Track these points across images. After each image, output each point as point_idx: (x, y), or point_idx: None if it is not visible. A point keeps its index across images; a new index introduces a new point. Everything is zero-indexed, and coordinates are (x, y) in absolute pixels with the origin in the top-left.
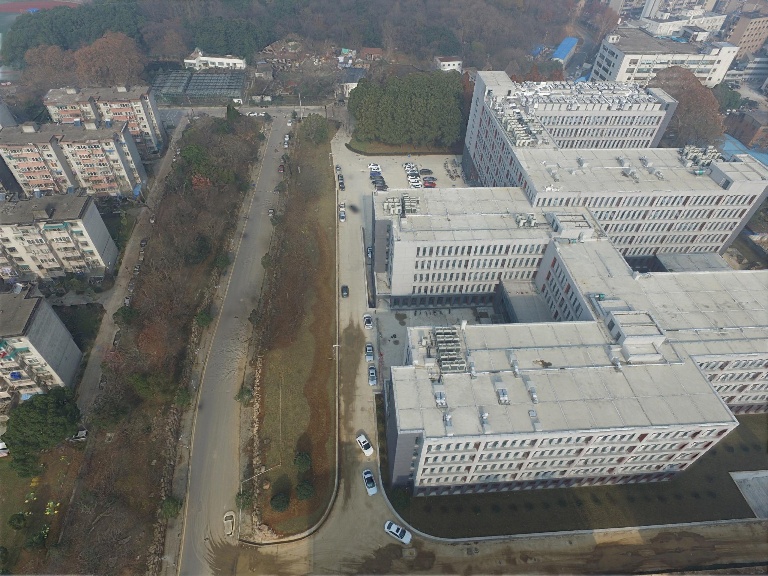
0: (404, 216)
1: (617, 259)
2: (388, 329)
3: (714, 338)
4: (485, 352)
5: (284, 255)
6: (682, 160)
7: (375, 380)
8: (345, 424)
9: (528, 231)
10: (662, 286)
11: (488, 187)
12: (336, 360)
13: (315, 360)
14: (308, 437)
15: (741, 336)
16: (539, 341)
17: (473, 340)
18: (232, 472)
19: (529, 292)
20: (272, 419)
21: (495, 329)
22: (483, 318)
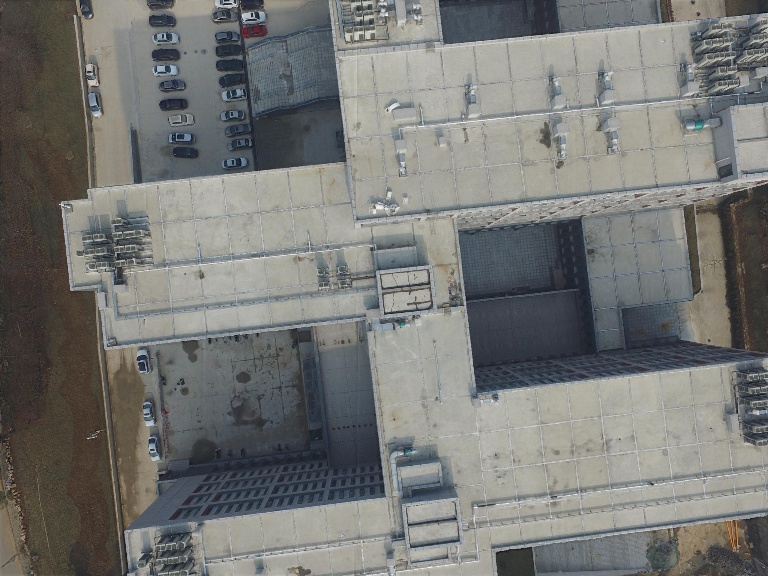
0: (120, 277)
1: (462, 359)
2: (173, 370)
3: (538, 512)
4: (227, 562)
5: (1, 238)
6: (686, 70)
7: (157, 456)
8: (129, 511)
9: (334, 297)
10: (509, 416)
11: (282, 169)
12: (106, 430)
13: (75, 442)
14: (82, 546)
15: (576, 506)
16: (302, 537)
17: (214, 543)
18: (16, 574)
19: (353, 340)
20: (37, 529)
21: (246, 521)
22: (303, 343)
